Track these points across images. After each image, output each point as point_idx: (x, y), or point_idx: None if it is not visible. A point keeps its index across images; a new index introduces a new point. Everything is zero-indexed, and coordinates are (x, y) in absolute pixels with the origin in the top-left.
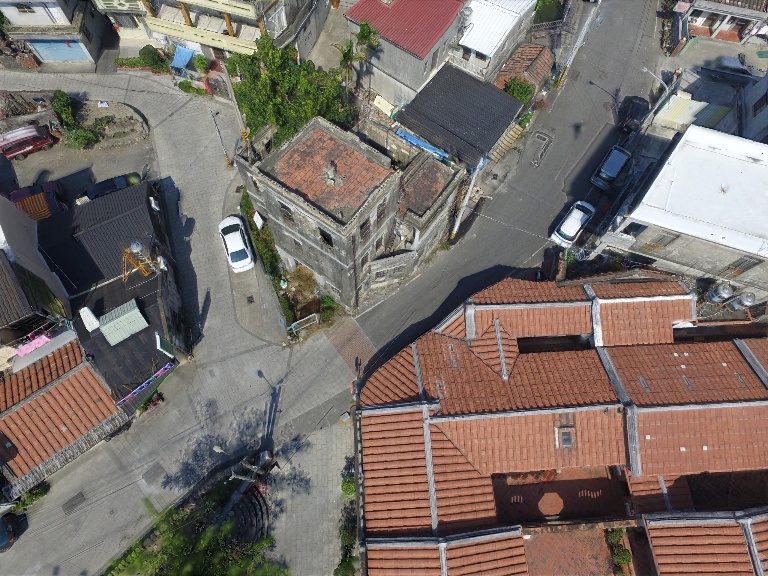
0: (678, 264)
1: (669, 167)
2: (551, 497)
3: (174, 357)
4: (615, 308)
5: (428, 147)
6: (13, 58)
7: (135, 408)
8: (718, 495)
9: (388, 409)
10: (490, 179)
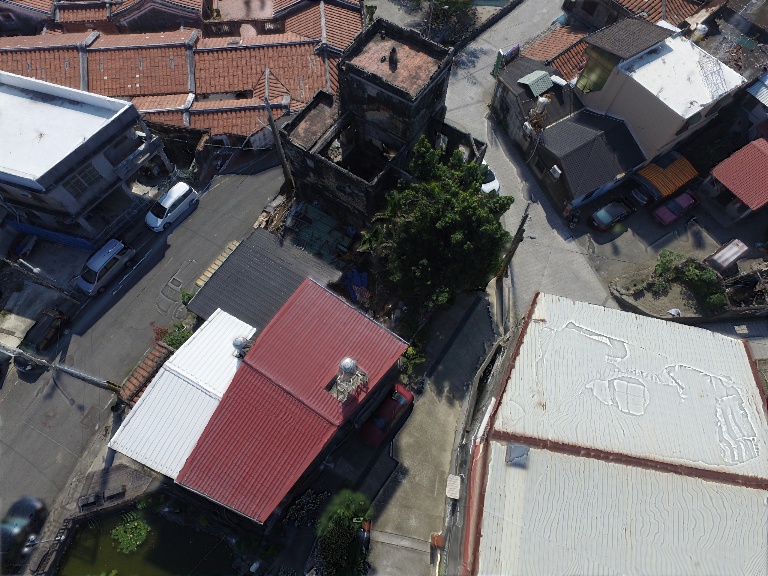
0: None
1: None
2: None
3: None
4: (171, 107)
5: None
6: None
7: None
8: None
9: None
10: None
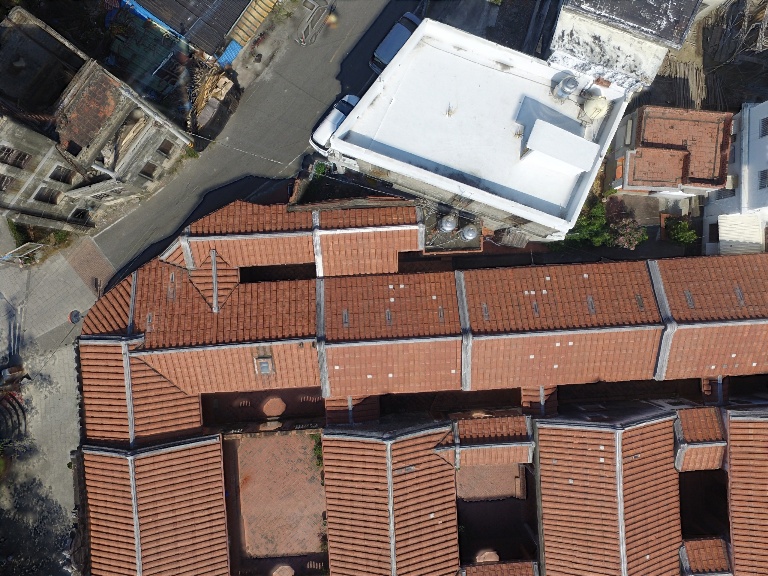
0: (412, 190)
1: (392, 79)
2: (276, 402)
3: None
4: (336, 239)
5: (160, 22)
6: None
7: None
8: (425, 400)
9: (98, 341)
10: (252, 61)
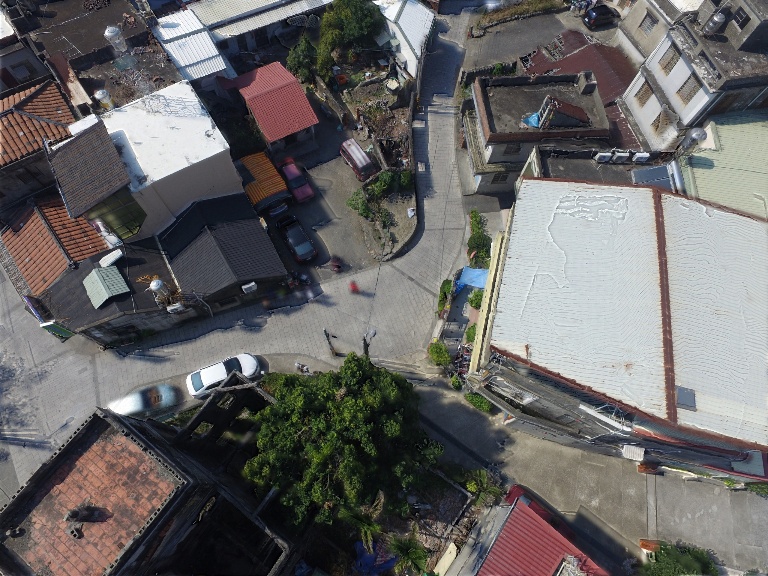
0: None
1: None
2: None
3: (66, 337)
4: None
5: None
6: (461, 126)
7: (31, 311)
8: None
9: None
10: None
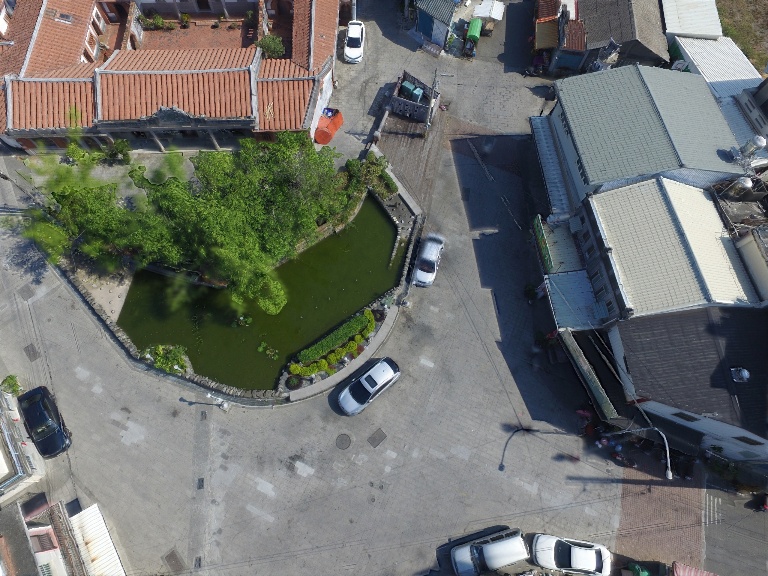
0: None
1: None
2: None
3: None
4: None
5: None
6: None
7: None
8: None
9: (8, 107)
10: None
